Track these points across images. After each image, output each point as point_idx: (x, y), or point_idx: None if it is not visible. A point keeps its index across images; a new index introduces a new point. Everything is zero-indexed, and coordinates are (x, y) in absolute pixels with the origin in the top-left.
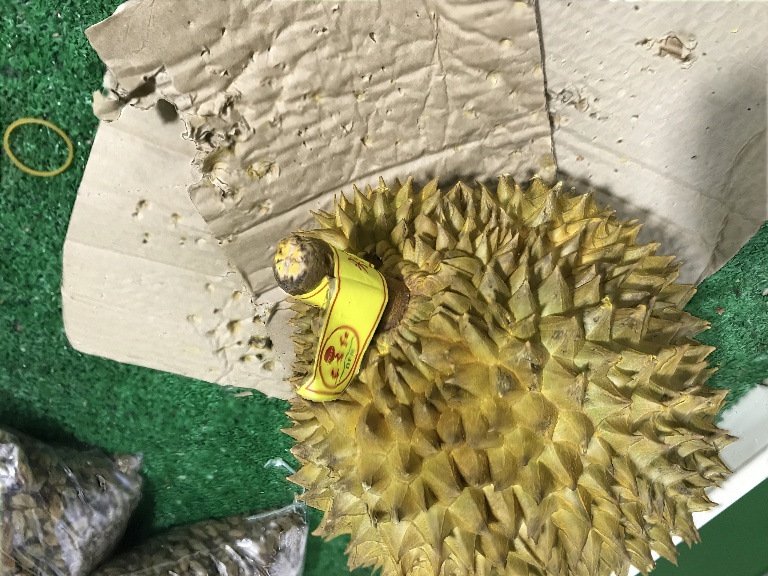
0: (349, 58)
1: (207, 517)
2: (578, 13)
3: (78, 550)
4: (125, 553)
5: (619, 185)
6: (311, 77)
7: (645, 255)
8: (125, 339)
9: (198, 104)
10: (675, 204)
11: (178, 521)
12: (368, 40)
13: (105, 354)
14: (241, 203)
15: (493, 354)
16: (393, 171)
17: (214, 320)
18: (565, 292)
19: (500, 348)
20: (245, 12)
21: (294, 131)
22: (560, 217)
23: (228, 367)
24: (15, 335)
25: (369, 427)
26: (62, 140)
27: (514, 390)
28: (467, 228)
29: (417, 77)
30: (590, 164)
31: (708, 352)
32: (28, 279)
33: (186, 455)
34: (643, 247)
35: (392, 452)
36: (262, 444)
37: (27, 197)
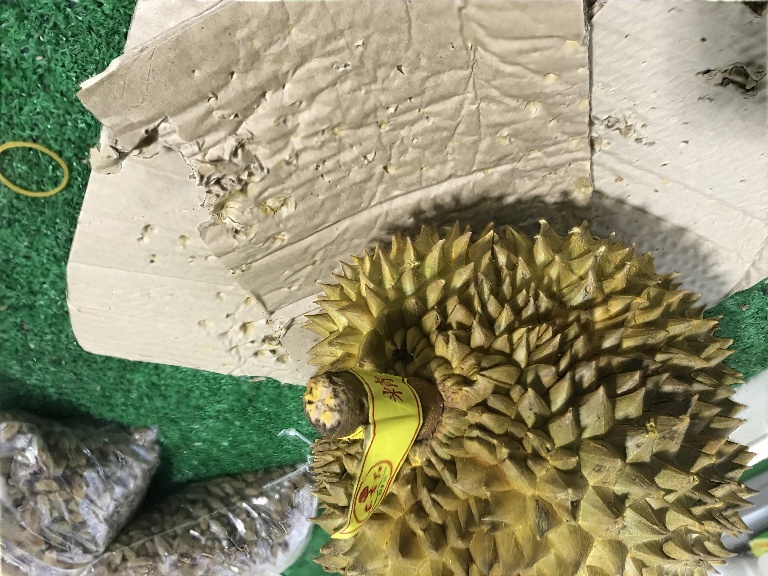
0: (373, 90)
1: (223, 474)
2: (636, 44)
3: (103, 522)
4: (147, 514)
5: (658, 204)
6: (330, 112)
7: (688, 330)
8: (136, 343)
9: (206, 149)
10: (715, 223)
11: (195, 477)
12: (395, 72)
13: (116, 354)
14: (255, 238)
15: (531, 486)
16: (417, 194)
17: (226, 324)
18: (608, 413)
19: (538, 477)
20: (257, 54)
21: (311, 166)
22: (600, 286)
23: (241, 361)
24: (22, 333)
25: (402, 553)
26: (56, 162)
27: (552, 527)
28: (504, 321)
29: (448, 106)
30: (629, 184)
31: None
32: (31, 286)
33: (201, 427)
34: (686, 323)
35: (424, 568)
36: (276, 418)
37: (23, 214)
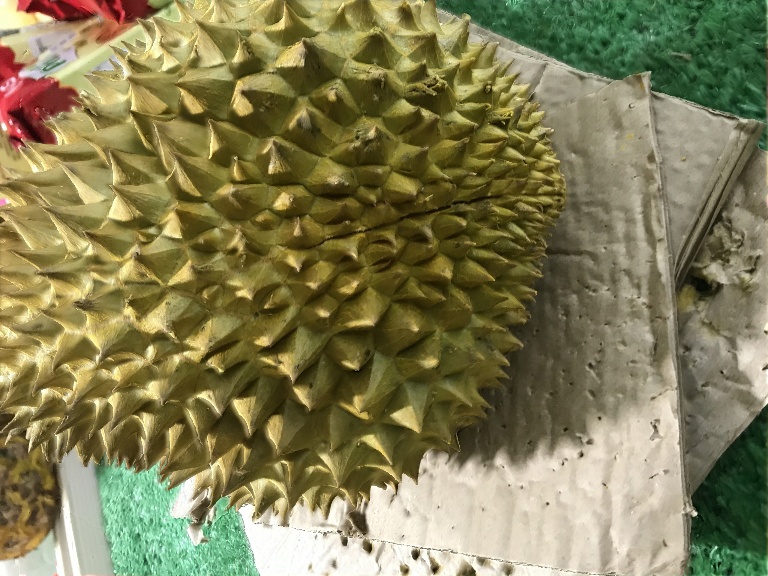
0: None
1: None
2: None
3: None
4: None
5: None
6: None
7: None
8: None
9: None
10: None
11: None
12: None
13: None
14: None
15: None
16: None
17: None
18: None
19: None
20: None
21: None
22: None
23: None
24: None
25: None
26: None
27: None
28: None
29: None
30: None
31: None
32: None
33: None
34: None
35: None
36: None
37: None
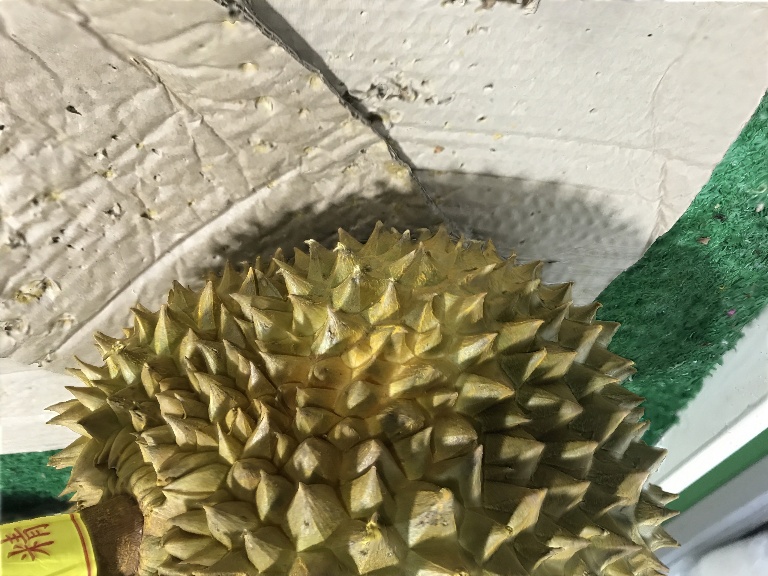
0: (62, 142)
1: None
2: None
3: None
4: None
5: (505, 164)
6: (25, 181)
7: (487, 348)
8: (30, 437)
9: None
10: (589, 167)
11: None
12: (70, 116)
13: (22, 450)
14: (32, 329)
15: None
16: (206, 231)
17: None
18: (321, 514)
19: None
20: None
21: (46, 240)
22: (366, 316)
23: None
24: None
25: None
26: None
27: None
28: (212, 403)
29: (167, 131)
30: (455, 151)
31: (621, 417)
32: None
33: None
34: (481, 340)
35: None
36: None
37: None
